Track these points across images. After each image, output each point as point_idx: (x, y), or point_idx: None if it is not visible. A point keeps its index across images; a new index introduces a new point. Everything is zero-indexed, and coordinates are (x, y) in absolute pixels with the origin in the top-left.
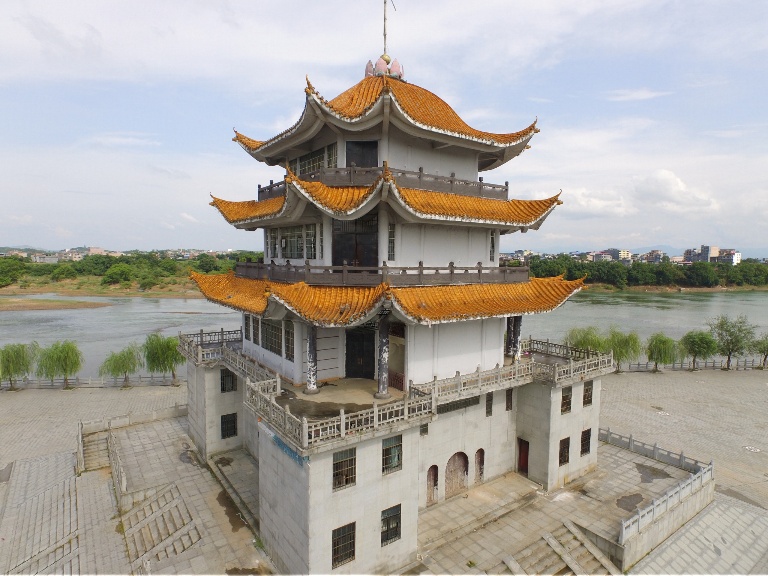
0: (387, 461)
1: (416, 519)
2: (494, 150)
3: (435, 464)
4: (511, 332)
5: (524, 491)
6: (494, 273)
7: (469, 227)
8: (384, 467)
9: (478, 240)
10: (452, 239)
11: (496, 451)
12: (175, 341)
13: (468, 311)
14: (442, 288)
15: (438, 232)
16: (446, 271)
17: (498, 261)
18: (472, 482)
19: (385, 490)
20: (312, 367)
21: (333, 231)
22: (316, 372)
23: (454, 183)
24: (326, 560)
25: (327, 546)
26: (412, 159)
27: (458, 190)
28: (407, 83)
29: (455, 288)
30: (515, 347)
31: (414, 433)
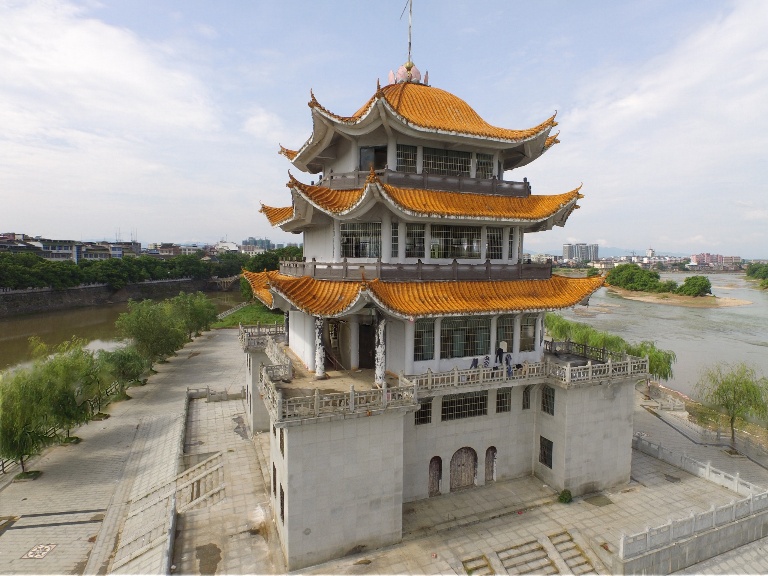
0: None
1: None
2: (325, 142)
3: None
4: None
5: None
6: None
7: None
8: None
9: None
10: None
11: None
12: (660, 353)
13: None
14: None
15: None
16: None
17: (335, 257)
18: None
19: None
20: None
21: None
22: None
23: None
24: None
25: None
26: None
27: None
28: None
29: None
30: None
31: None
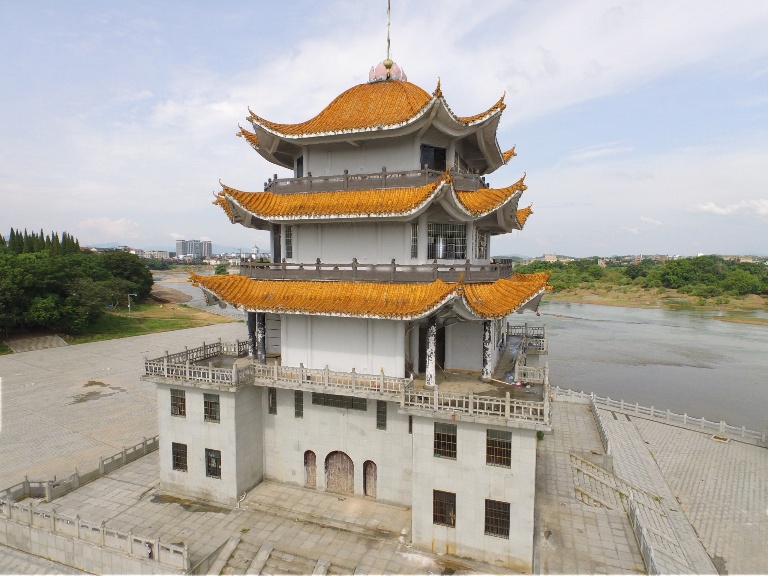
0: (208, 411)
1: (234, 472)
2: (403, 132)
3: (312, 450)
4: (484, 349)
5: (388, 526)
6: (375, 271)
7: (376, 222)
8: (206, 415)
9: (392, 235)
10: (356, 236)
11: (395, 474)
12: None
13: (296, 305)
14: (302, 283)
15: (338, 230)
16: (311, 267)
17: (422, 258)
18: (360, 491)
19: (207, 433)
20: (249, 339)
21: (274, 235)
22: (253, 343)
23: (346, 180)
24: (169, 460)
25: (169, 451)
26: (333, 163)
27: (353, 186)
28: (394, 81)
29: (318, 284)
30: (426, 361)
31: (230, 398)
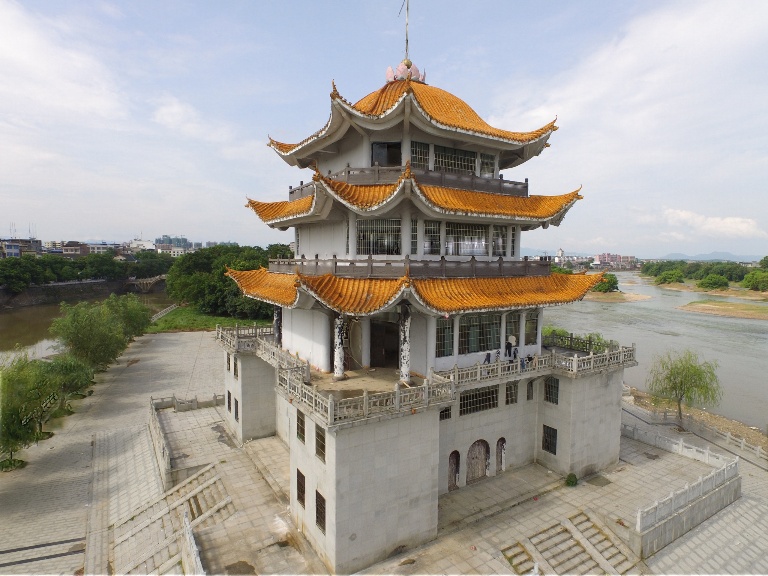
0: None
1: (241, 419)
2: (337, 136)
3: None
4: None
5: None
6: (310, 265)
7: None
8: None
9: (338, 233)
10: (323, 234)
11: None
12: None
13: None
14: (282, 275)
15: (316, 230)
16: None
17: (350, 254)
18: None
19: None
20: None
21: None
22: None
23: None
24: None
25: None
26: None
27: None
28: None
29: None
30: None
31: None
